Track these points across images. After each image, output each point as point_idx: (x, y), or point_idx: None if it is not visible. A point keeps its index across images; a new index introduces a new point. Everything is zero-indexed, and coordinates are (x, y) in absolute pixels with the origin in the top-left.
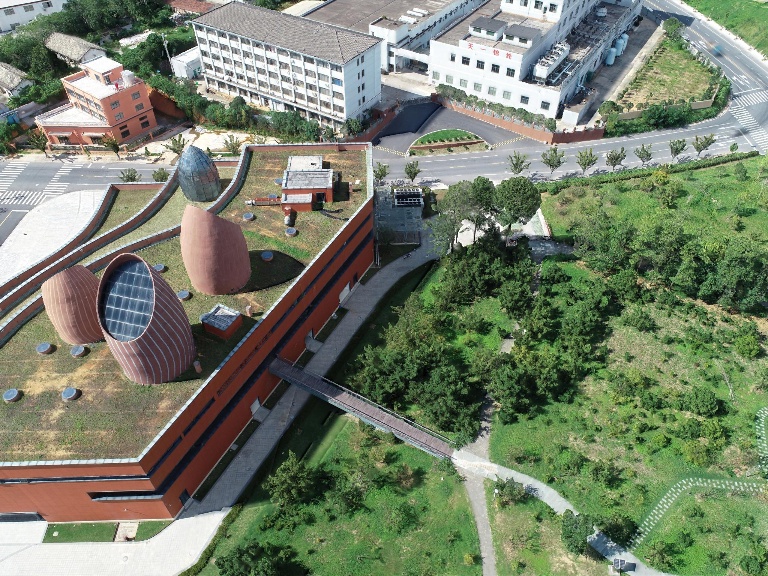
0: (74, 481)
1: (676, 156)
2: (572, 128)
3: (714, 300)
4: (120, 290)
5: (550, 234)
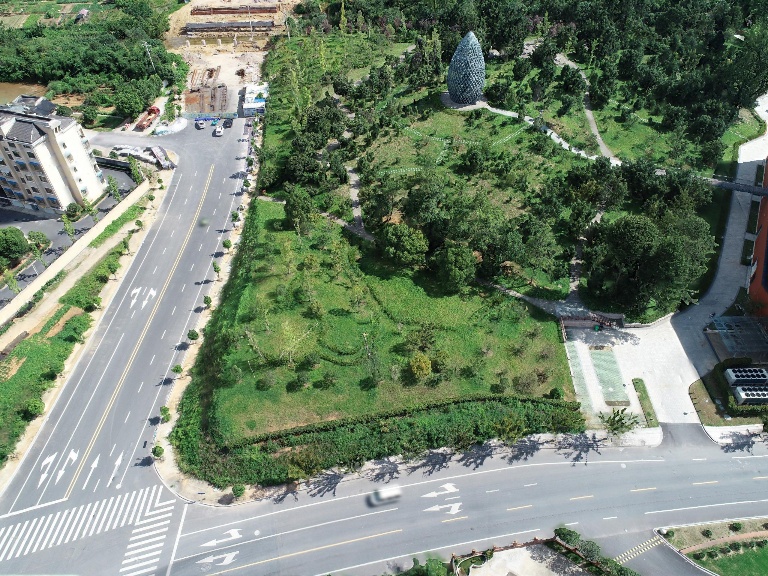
0: None
1: (336, 495)
2: (514, 571)
3: None
4: None
5: None
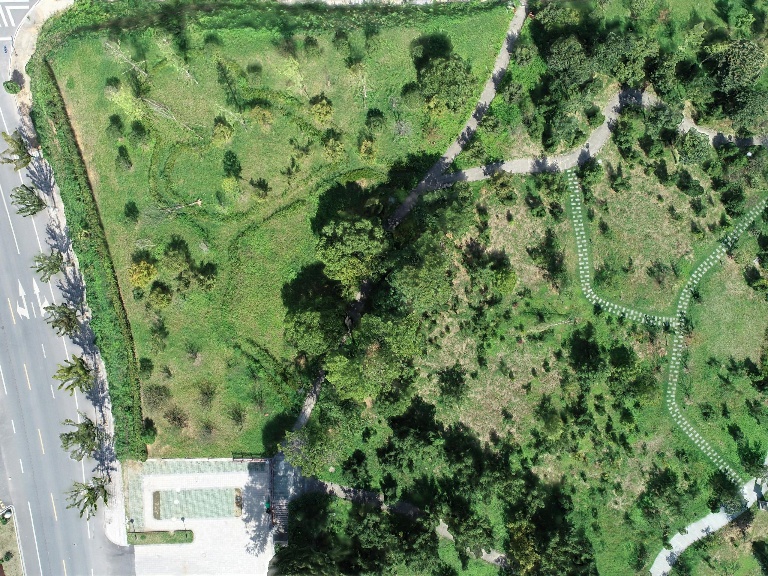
0: None
1: None
2: None
3: None
4: None
5: (261, 461)
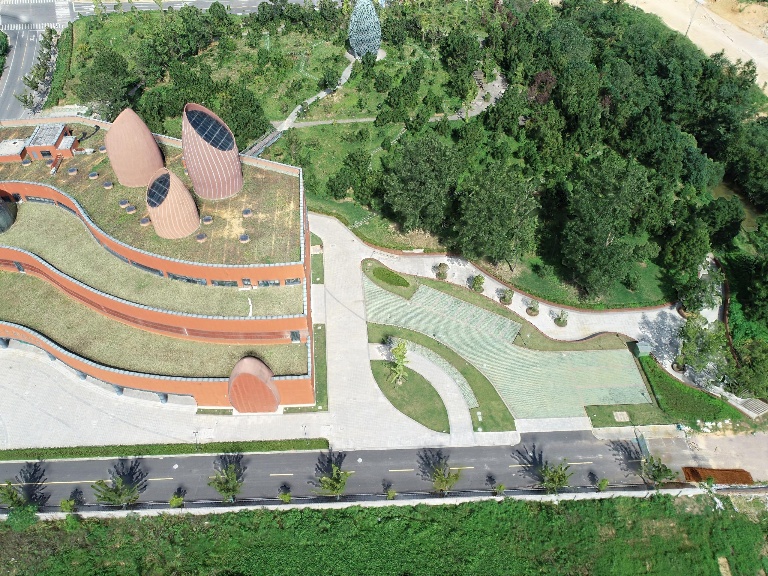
0: (304, 213)
1: None
2: None
3: (197, 50)
4: (201, 132)
5: None
